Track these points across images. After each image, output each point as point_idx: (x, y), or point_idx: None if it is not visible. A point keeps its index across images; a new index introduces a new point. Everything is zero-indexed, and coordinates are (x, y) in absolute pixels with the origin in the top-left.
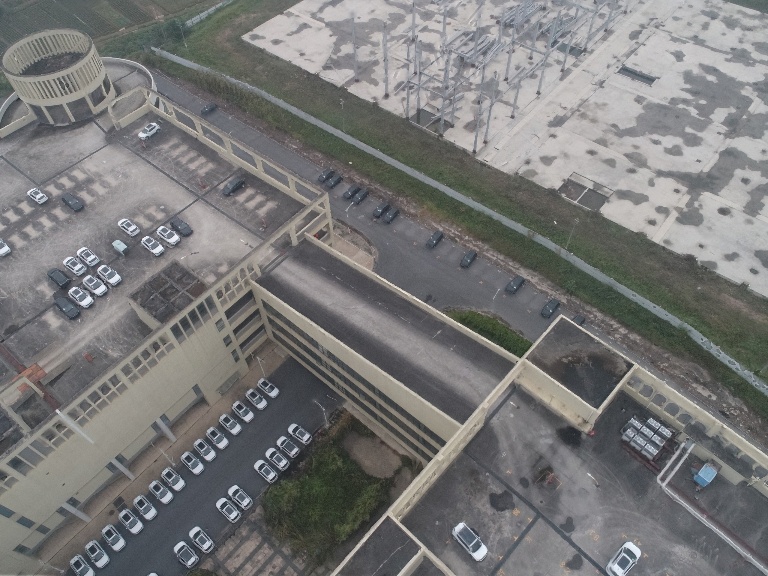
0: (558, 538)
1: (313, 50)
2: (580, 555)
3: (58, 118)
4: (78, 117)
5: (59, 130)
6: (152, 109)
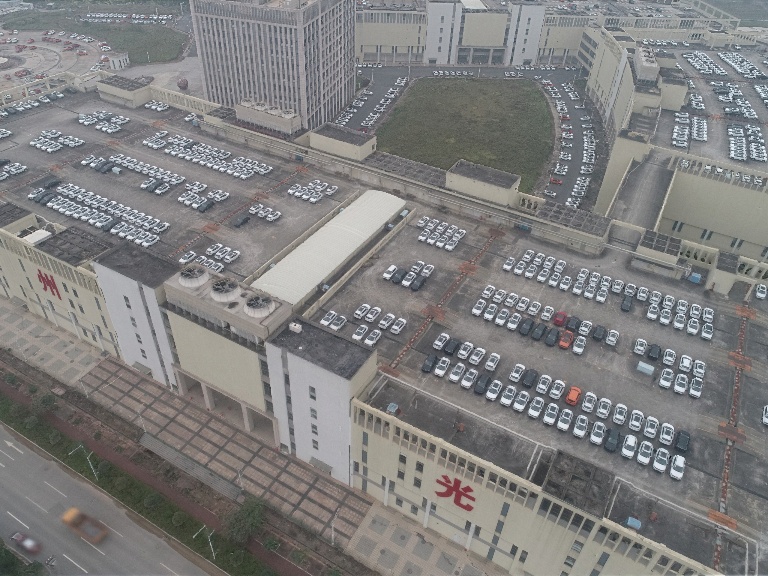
0: (759, 54)
1: (755, 36)
2: (763, 56)
3: (660, 1)
4: (666, 2)
5: (659, 3)
6: (691, 6)
